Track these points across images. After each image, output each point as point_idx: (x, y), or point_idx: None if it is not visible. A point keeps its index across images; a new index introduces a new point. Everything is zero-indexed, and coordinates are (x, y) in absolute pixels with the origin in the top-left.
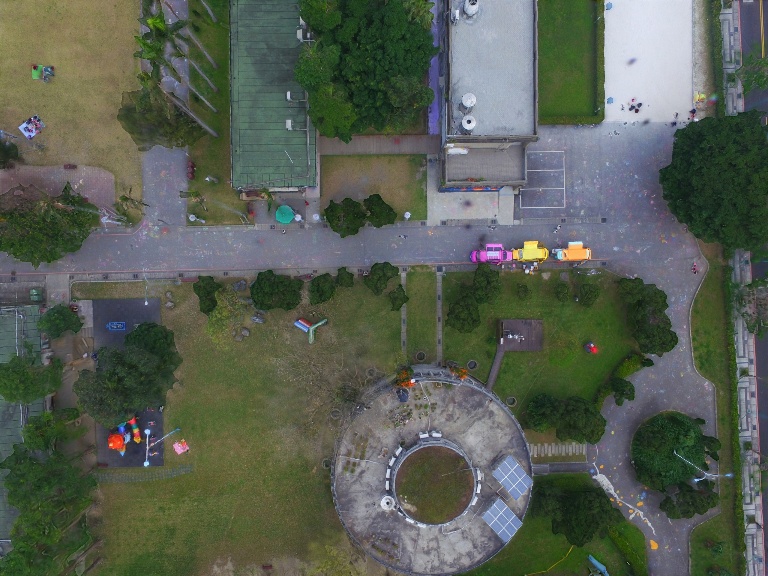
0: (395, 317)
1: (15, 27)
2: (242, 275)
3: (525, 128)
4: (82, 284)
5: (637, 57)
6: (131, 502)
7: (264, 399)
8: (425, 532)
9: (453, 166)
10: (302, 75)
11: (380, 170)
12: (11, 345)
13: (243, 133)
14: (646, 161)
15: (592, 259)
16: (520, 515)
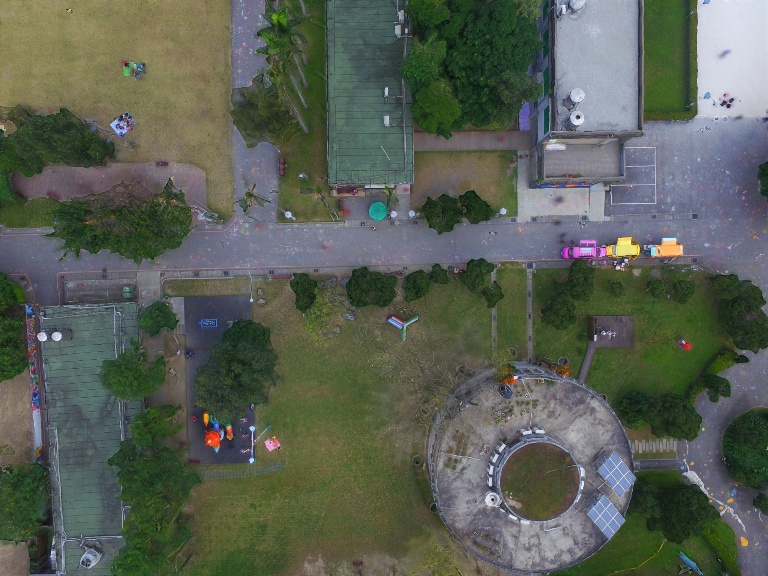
0: (485, 314)
1: (106, 24)
2: (332, 272)
3: (629, 124)
4: (173, 281)
5: (729, 52)
6: (223, 499)
7: (355, 396)
8: (526, 529)
9: (550, 162)
10: (413, 71)
11: (470, 166)
12: (109, 342)
13: (339, 129)
14: (738, 157)
15: (683, 255)
16: (621, 512)
